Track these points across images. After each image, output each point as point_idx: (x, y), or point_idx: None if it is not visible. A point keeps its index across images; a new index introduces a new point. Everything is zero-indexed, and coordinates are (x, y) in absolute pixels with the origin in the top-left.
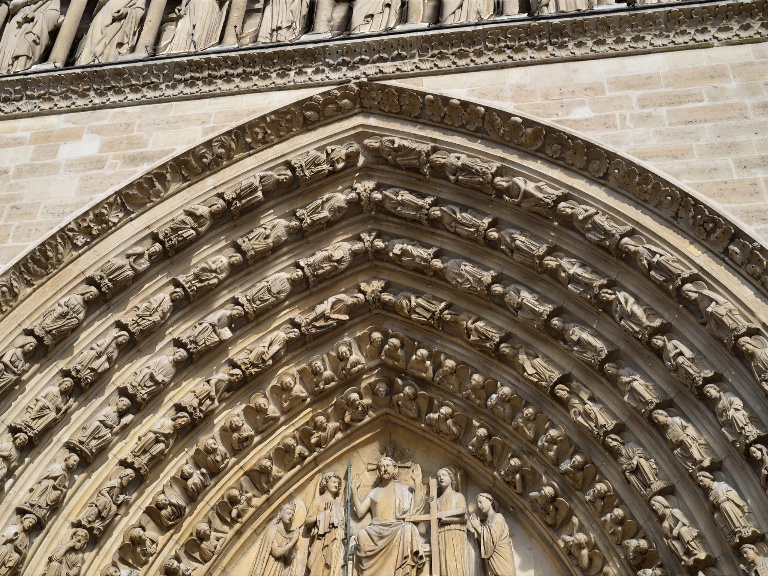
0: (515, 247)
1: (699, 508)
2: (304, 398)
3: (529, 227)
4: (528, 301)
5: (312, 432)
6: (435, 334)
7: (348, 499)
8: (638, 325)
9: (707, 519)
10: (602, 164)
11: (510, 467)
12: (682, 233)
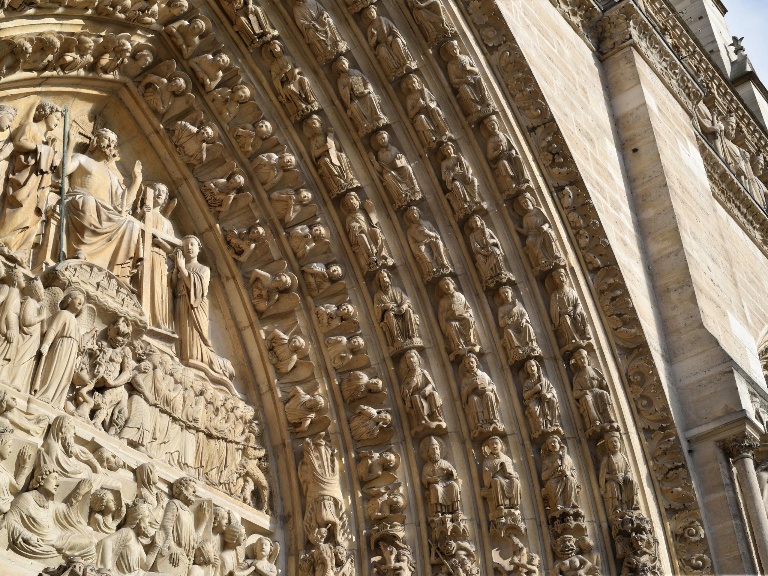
0: (391, 42)
1: (444, 381)
2: (90, 6)
3: (404, 33)
4: (375, 98)
5: (73, 48)
6: (240, 50)
7: (65, 148)
8: (470, 195)
9: (449, 394)
10: (497, 36)
11: (256, 233)
12: (529, 146)
